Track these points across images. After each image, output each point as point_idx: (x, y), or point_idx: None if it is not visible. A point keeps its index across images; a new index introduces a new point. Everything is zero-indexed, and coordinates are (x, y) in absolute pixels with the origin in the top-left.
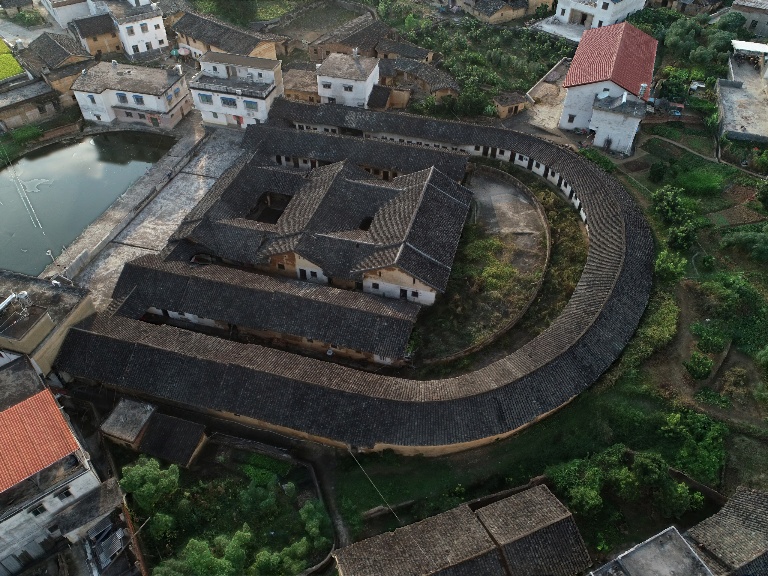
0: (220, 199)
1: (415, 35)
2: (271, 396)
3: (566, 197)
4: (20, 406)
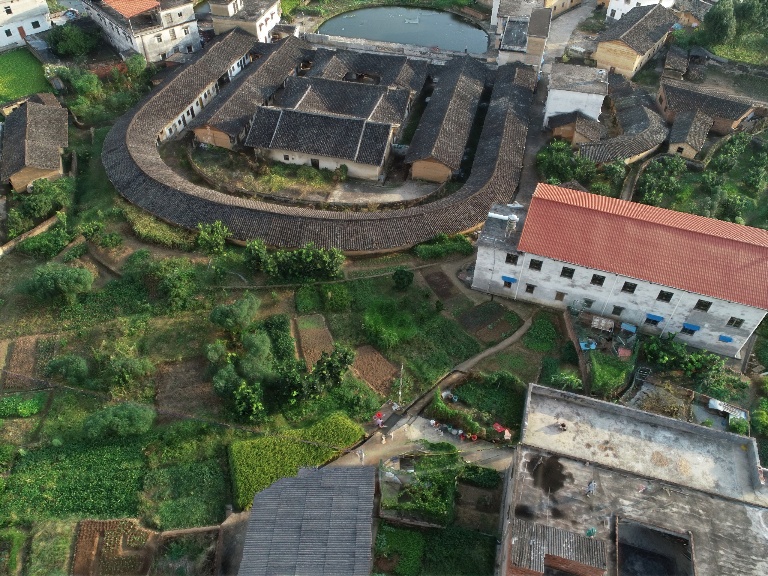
0: (360, 54)
1: (748, 141)
2: (167, 82)
3: None
4: (153, 0)
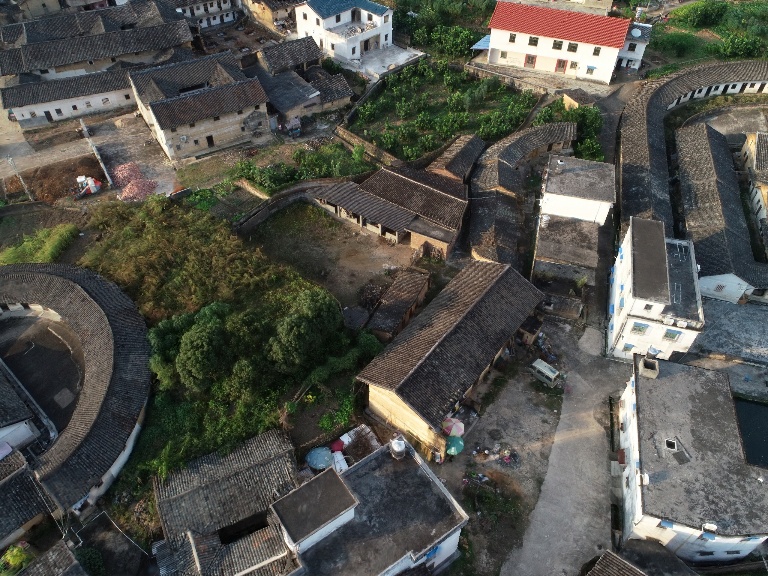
0: None
1: None
2: None
3: (703, 98)
4: None
